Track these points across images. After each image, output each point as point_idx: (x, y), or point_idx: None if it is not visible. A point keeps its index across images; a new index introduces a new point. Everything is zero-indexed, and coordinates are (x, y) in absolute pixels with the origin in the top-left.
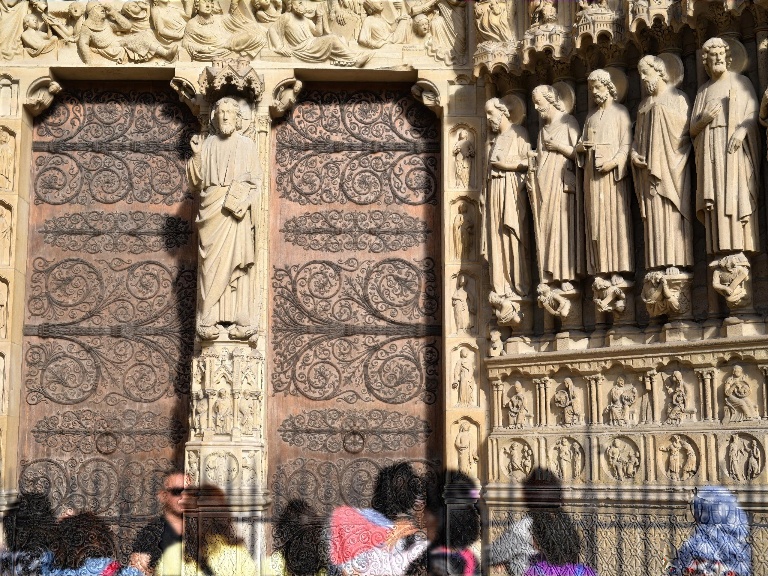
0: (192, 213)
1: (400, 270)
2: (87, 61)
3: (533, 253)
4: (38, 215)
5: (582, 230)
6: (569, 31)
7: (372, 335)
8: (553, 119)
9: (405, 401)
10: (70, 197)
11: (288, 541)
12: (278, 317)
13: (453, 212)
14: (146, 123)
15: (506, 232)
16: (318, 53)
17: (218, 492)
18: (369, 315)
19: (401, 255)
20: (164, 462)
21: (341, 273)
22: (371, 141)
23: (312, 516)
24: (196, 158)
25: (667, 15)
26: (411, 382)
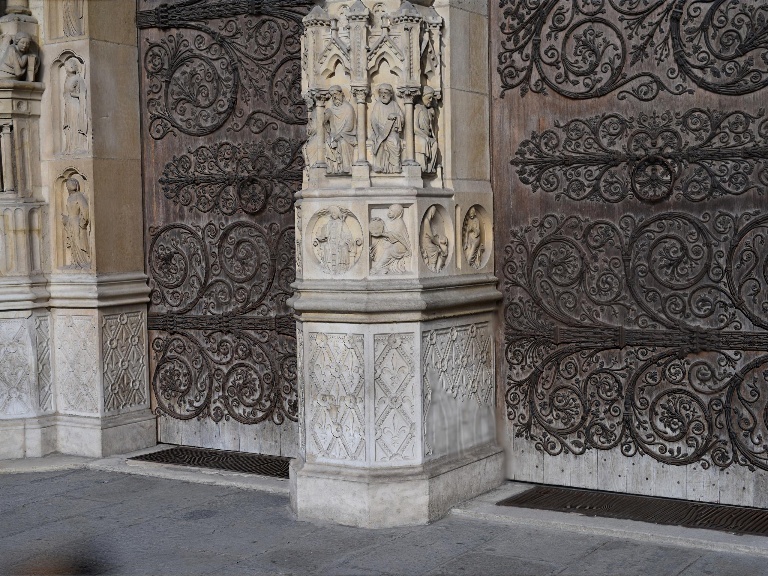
0: None
1: None
2: None
3: None
4: None
5: None
6: None
7: None
8: None
9: (758, 87)
10: None
11: (533, 371)
12: None
13: None
14: None
15: None
16: None
17: (328, 286)
18: None
19: None
20: None
21: None
22: None
23: (574, 326)
24: None
25: None
26: None
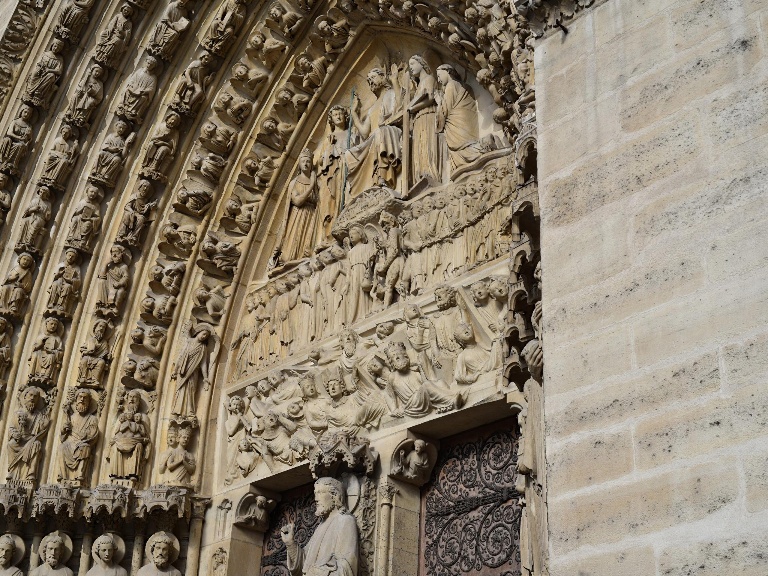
0: None
1: None
2: (271, 470)
3: None
4: None
5: None
6: None
7: None
8: None
9: None
10: None
11: None
12: None
13: None
14: None
15: None
16: None
17: None
18: None
19: None
20: None
21: None
22: (501, 489)
23: None
24: (288, 548)
25: (530, 248)
26: None
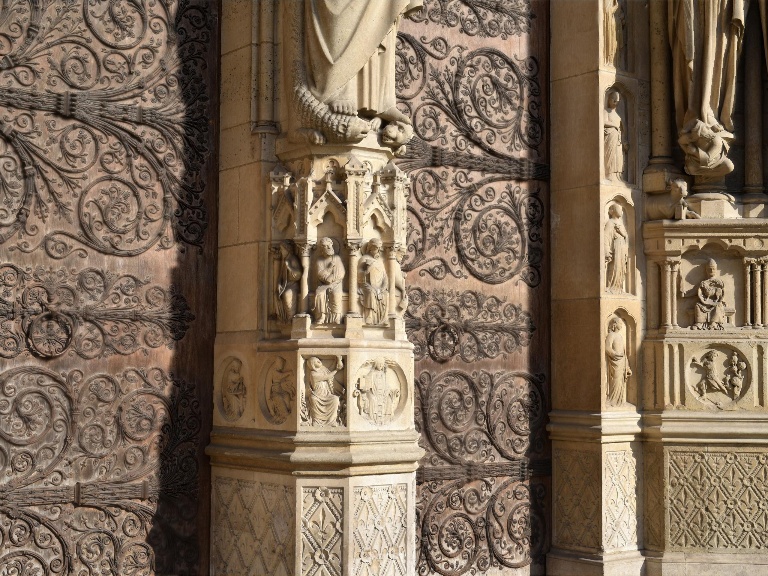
0: None
1: (499, 69)
2: None
3: None
4: None
5: None
6: None
7: (464, 169)
8: None
9: (505, 280)
10: None
11: None
12: None
13: None
14: None
15: (727, 31)
16: None
17: (381, 437)
18: (460, 136)
19: (500, 46)
20: (156, 376)
21: (425, 59)
22: None
23: None
24: None
25: None
26: (511, 250)
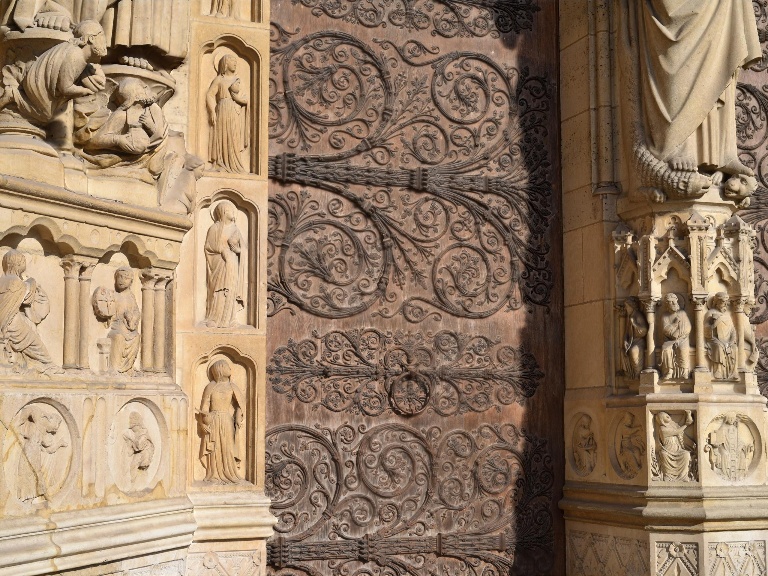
0: None
1: None
2: None
3: None
4: None
5: None
6: None
7: None
8: None
9: None
10: None
11: None
12: None
13: None
14: None
15: None
16: None
17: (736, 493)
18: None
19: None
20: (509, 431)
21: None
22: None
23: None
24: None
25: None
26: None
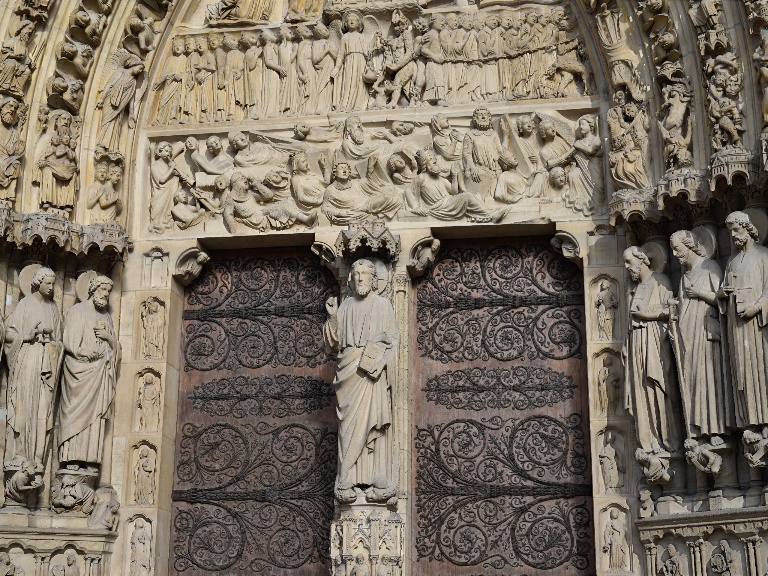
0: (335, 375)
1: (546, 427)
2: (232, 231)
3: (682, 406)
4: (188, 381)
5: (730, 380)
6: (705, 174)
7: (519, 496)
8: (693, 265)
9: (555, 566)
10: (218, 363)
11: None
12: (422, 479)
13: (597, 365)
14: (290, 288)
15: (650, 384)
16: (454, 211)
17: None
18: (515, 475)
19: (547, 412)
20: None
21: (485, 432)
22: (512, 296)
23: None
24: (332, 320)
25: None
26: (561, 546)
